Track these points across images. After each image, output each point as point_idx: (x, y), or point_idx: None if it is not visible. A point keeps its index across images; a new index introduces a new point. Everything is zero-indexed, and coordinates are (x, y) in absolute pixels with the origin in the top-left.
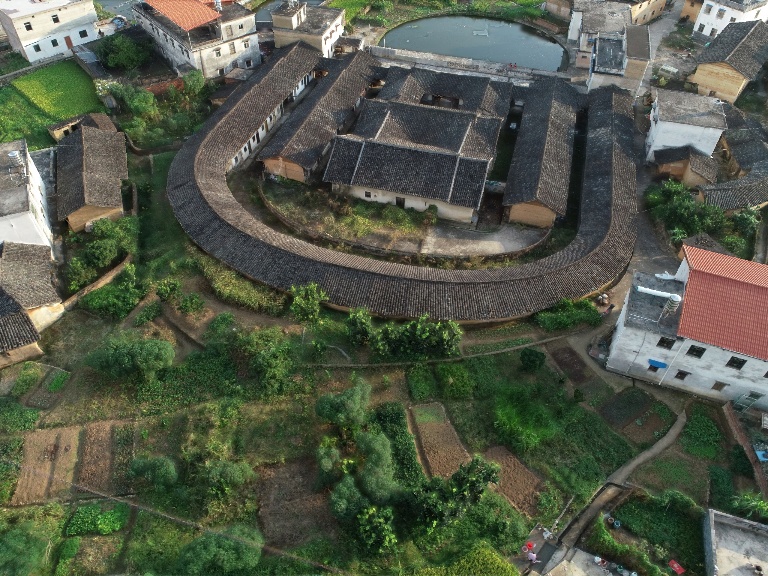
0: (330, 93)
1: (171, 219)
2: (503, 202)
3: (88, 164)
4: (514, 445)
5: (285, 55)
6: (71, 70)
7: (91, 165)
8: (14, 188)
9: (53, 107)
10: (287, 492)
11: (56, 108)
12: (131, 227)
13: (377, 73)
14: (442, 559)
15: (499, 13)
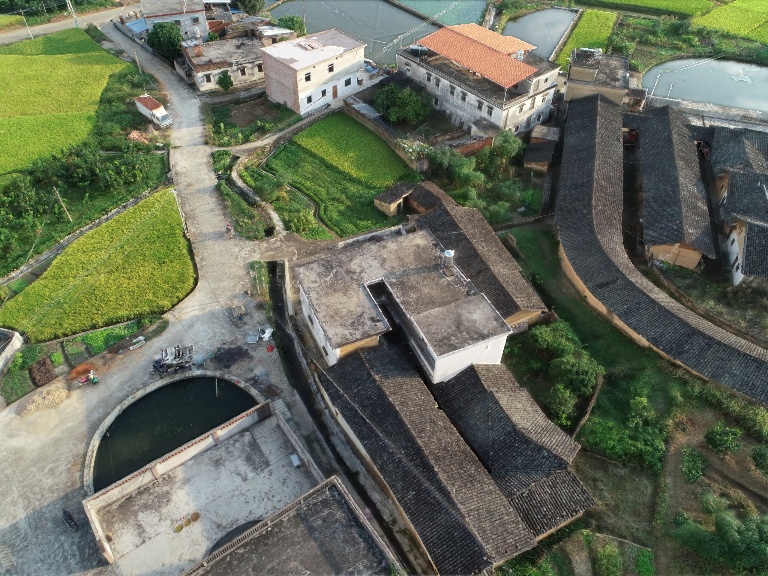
0: (677, 160)
1: (599, 323)
2: None
3: (483, 254)
4: None
5: (593, 112)
6: (350, 125)
7: (486, 255)
8: (470, 298)
9: (359, 171)
10: None
11: (363, 172)
12: (575, 337)
13: (695, 133)
14: None
15: (751, 56)
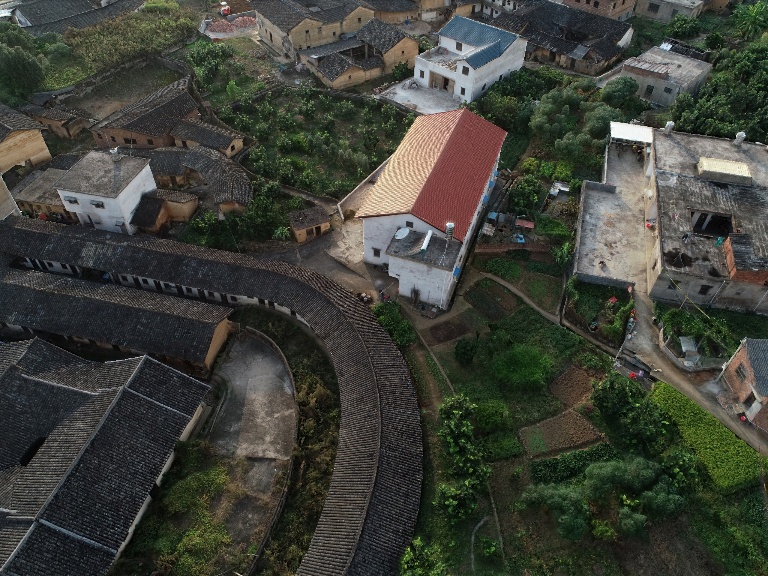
0: None
1: None
2: (200, 361)
3: None
4: (550, 376)
5: None
6: None
7: None
8: None
9: None
10: (659, 569)
11: None
12: None
13: None
14: (667, 432)
15: None
